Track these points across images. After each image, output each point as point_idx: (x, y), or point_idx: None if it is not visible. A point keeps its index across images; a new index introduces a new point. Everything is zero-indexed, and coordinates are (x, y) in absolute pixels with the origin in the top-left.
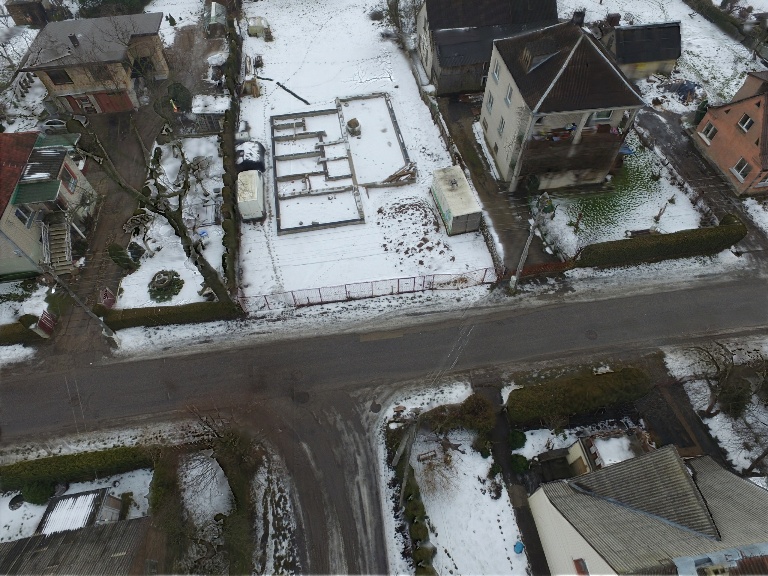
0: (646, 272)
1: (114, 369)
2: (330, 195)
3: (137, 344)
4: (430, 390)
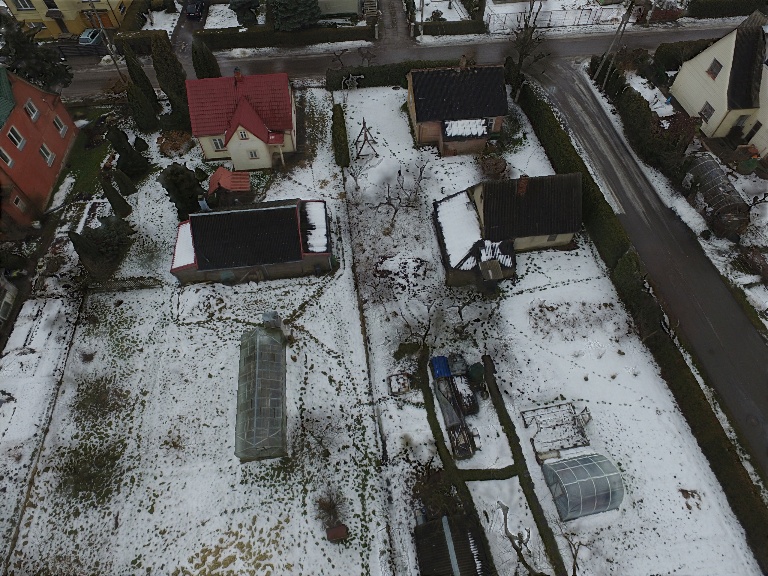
0: (727, 20)
1: (422, 50)
2: None
3: (431, 41)
4: None
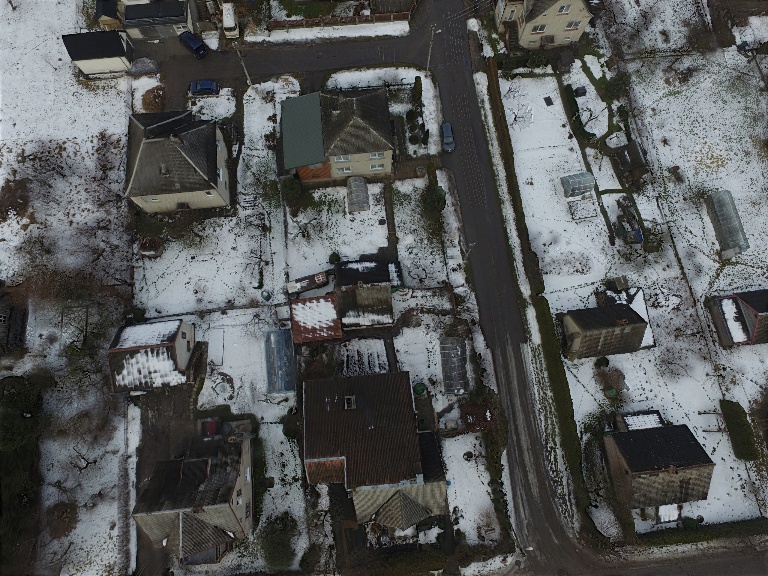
0: None
1: None
2: None
3: None
4: (486, 573)
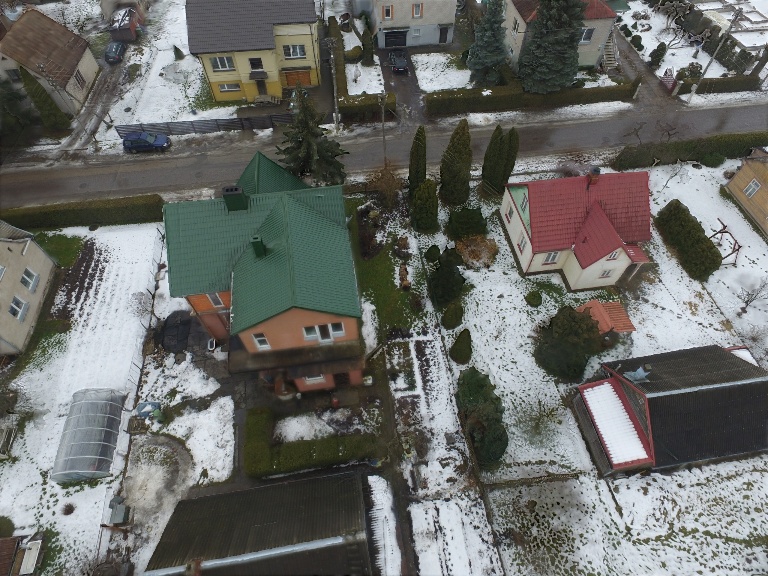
0: None
1: (696, 113)
2: (761, 31)
3: (701, 101)
4: None
